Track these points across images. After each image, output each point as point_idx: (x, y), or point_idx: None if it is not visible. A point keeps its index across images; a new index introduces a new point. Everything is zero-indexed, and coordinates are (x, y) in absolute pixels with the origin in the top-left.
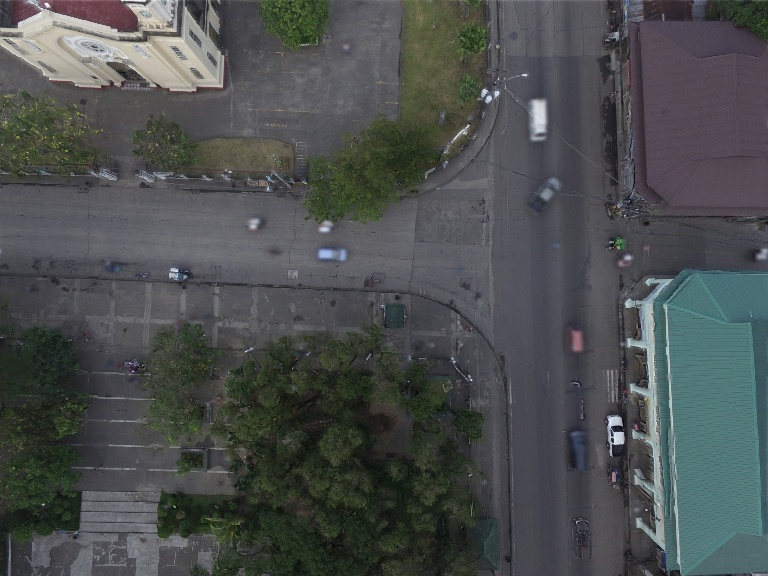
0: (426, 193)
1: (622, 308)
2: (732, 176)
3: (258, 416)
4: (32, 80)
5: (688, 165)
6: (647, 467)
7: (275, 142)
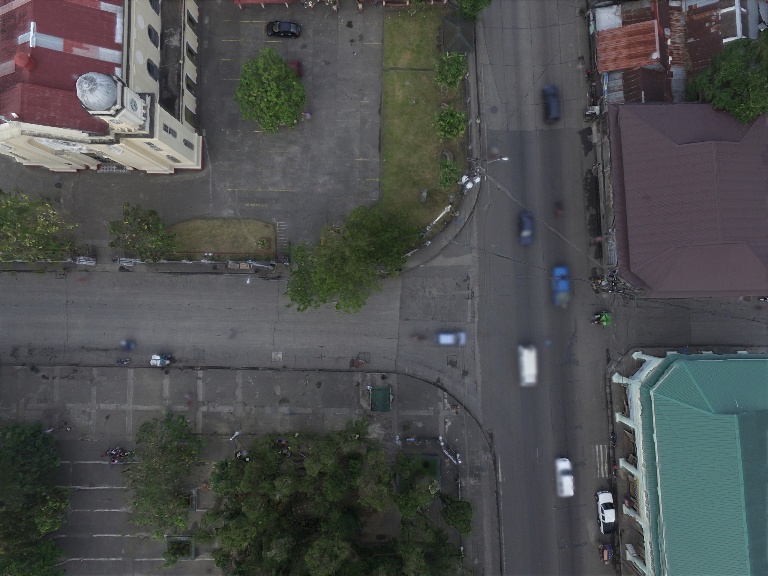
0: (410, 270)
1: (609, 382)
2: (715, 261)
3: (242, 528)
4: (5, 164)
5: (671, 252)
6: (638, 543)
7: (256, 222)
